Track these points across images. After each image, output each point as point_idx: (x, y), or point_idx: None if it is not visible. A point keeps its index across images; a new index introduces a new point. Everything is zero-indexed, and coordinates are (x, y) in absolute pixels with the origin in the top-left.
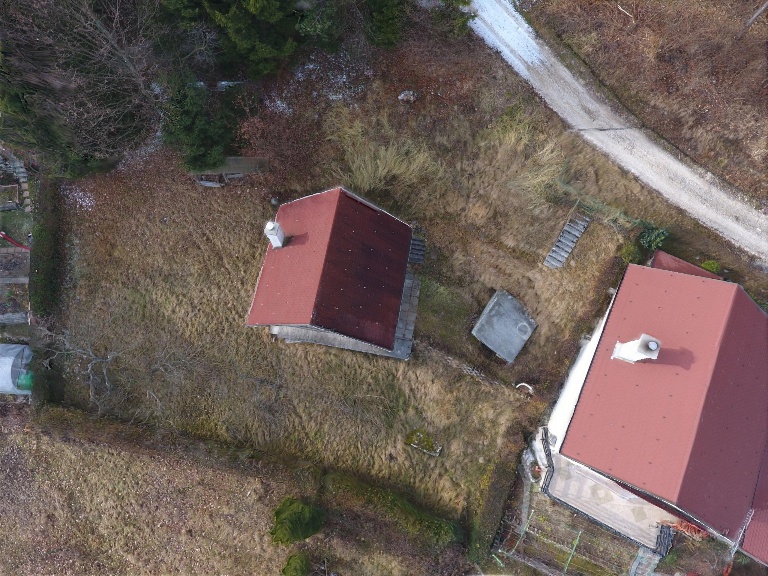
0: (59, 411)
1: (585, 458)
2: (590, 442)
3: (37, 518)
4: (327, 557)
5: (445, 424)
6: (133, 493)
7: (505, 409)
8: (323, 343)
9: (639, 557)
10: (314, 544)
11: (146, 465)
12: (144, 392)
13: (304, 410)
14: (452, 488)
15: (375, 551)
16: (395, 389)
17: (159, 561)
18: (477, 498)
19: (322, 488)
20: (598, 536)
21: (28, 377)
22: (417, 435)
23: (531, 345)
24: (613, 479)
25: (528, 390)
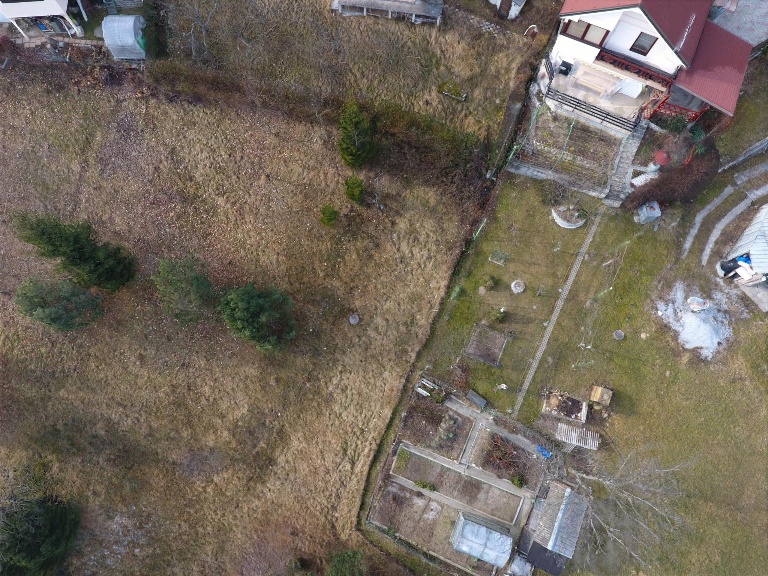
0: (169, 62)
1: (577, 9)
2: (580, 1)
3: (146, 170)
4: (377, 192)
5: (469, 75)
6: (223, 147)
7: (516, 57)
8: (374, 7)
9: (620, 151)
10: (367, 182)
11: (233, 123)
12: (231, 62)
13: (358, 70)
14: (475, 124)
15: (415, 186)
16: (429, 52)
17: (243, 203)
18: (495, 130)
19: (373, 132)
20: (589, 141)
21: (142, 42)
22: (447, 86)
23: (535, 0)
24: (598, 47)
25: (533, 29)
